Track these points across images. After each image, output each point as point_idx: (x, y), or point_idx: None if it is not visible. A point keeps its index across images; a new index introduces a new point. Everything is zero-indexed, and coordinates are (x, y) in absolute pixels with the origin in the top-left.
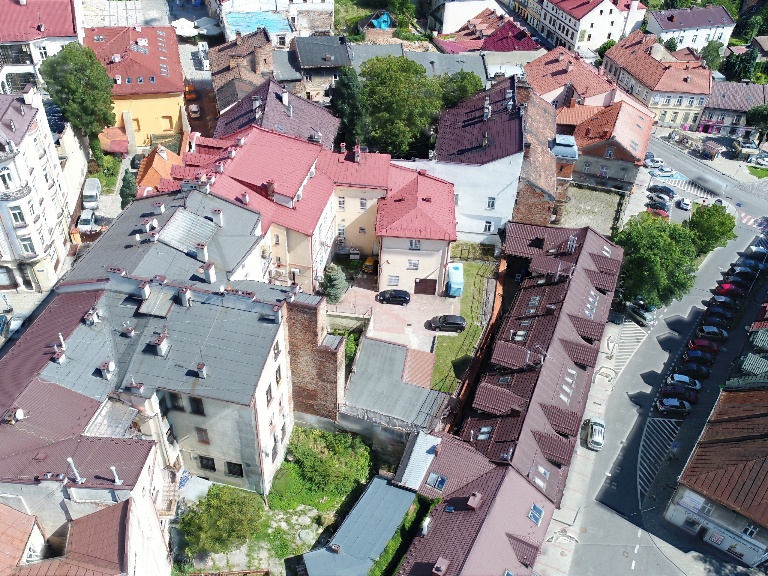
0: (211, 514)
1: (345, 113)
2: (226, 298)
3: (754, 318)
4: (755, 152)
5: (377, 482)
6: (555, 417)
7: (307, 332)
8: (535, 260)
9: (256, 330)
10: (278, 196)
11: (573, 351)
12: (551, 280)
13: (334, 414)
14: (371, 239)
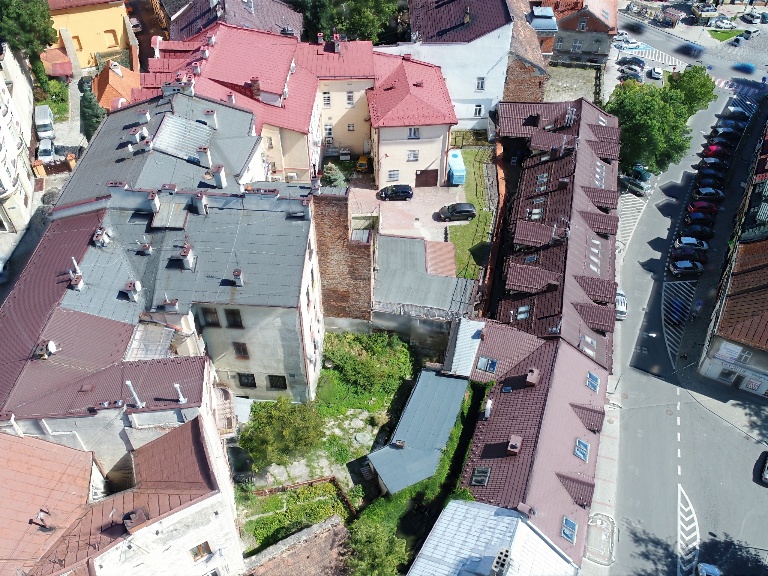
0: (274, 426)
1: (307, 6)
2: (247, 199)
3: (744, 176)
4: (714, 15)
5: (425, 375)
6: (591, 287)
7: (337, 227)
8: (535, 137)
9: (286, 229)
10: (264, 95)
11: (594, 221)
12: (556, 155)
13: (368, 314)
14: (361, 136)
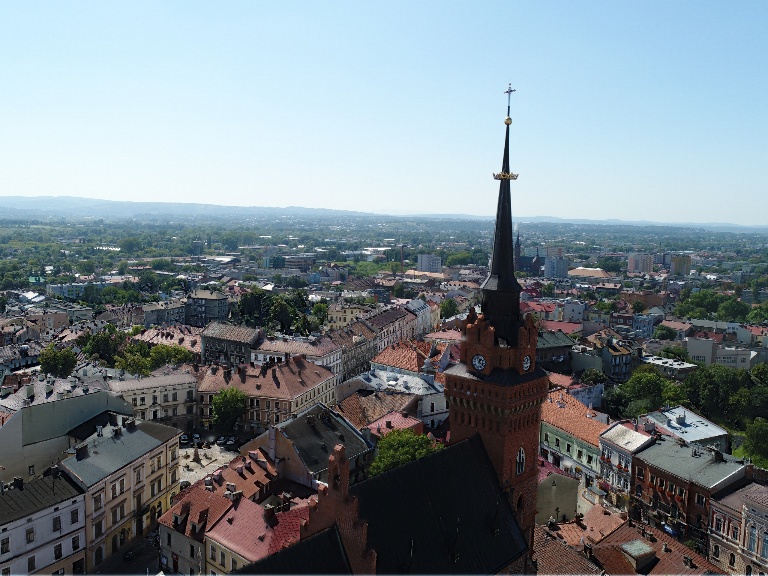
0: None
1: None
2: None
3: None
4: None
5: None
6: None
7: None
8: None
9: None
10: None
11: None
12: None
13: None
14: None
